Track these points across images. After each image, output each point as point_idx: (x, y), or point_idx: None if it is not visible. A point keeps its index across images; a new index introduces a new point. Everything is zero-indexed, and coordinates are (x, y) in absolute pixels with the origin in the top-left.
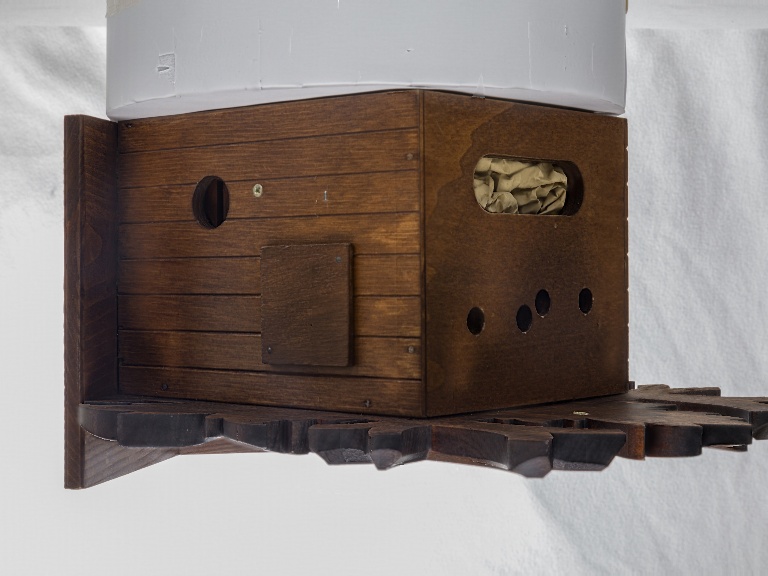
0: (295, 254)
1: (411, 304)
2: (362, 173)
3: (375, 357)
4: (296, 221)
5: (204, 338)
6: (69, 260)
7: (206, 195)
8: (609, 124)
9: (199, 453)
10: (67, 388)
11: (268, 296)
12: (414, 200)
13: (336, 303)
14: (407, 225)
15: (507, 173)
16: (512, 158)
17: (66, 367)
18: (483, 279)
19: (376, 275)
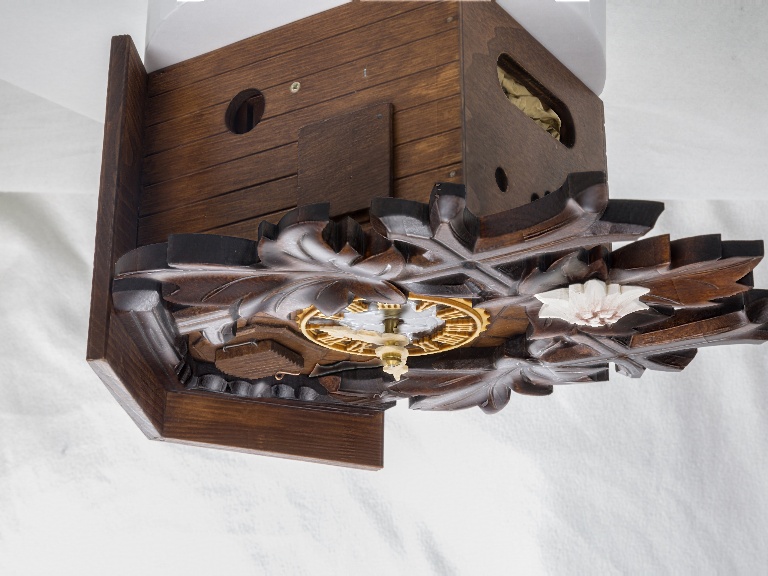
0: (335, 124)
1: (452, 136)
2: (402, 45)
3: (415, 191)
4: (334, 102)
5: (232, 229)
6: (108, 154)
7: (237, 116)
8: (591, 96)
9: (181, 438)
10: (97, 267)
11: (306, 166)
12: (454, 52)
13: (377, 152)
14: (448, 73)
15: (515, 93)
16: (521, 76)
17: (97, 248)
18: (506, 149)
19: (416, 123)
